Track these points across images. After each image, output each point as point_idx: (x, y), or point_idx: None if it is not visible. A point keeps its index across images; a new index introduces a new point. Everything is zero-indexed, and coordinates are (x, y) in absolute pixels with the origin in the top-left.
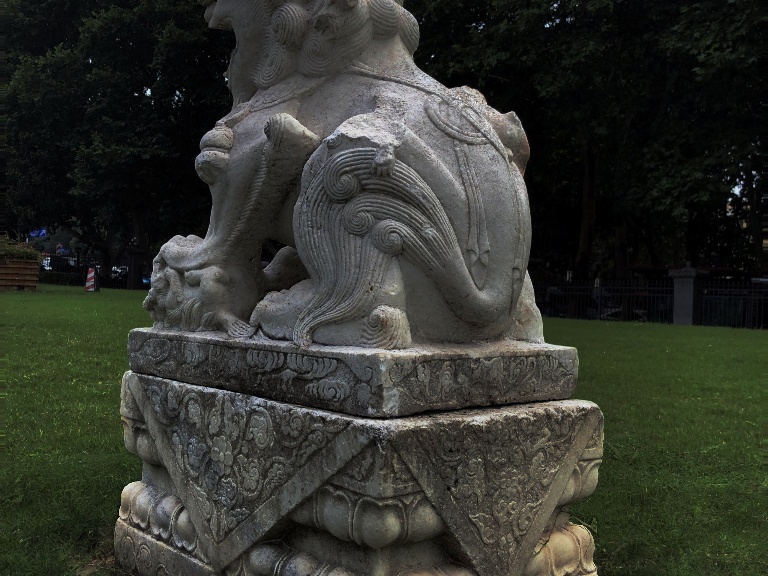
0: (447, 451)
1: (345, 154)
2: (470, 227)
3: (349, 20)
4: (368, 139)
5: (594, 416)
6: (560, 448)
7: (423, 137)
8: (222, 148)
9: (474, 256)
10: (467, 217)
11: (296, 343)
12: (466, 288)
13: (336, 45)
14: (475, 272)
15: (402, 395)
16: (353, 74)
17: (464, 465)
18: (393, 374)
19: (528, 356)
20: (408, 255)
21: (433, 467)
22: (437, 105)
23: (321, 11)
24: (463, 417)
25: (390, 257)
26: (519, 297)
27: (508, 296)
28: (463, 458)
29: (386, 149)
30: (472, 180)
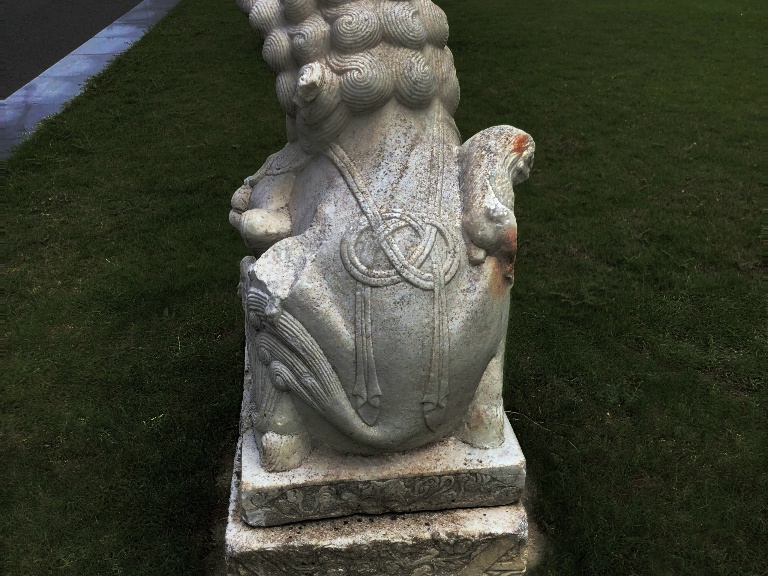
0: (299, 564)
1: (252, 292)
2: (357, 375)
3: (314, 111)
4: (265, 285)
5: (507, 540)
6: (454, 563)
7: (327, 277)
8: (241, 210)
9: (361, 400)
10: (354, 366)
11: (243, 421)
12: (349, 428)
13: (312, 129)
14: (364, 412)
15: (268, 513)
16: (328, 159)
17: (321, 573)
18: (255, 500)
19: (442, 475)
20: (295, 394)
21: (284, 573)
22: (355, 236)
23: (293, 97)
24: (324, 538)
25: (281, 392)
26: (473, 401)
27: (416, 426)
28: (319, 569)
29: (274, 301)
30: (364, 329)
